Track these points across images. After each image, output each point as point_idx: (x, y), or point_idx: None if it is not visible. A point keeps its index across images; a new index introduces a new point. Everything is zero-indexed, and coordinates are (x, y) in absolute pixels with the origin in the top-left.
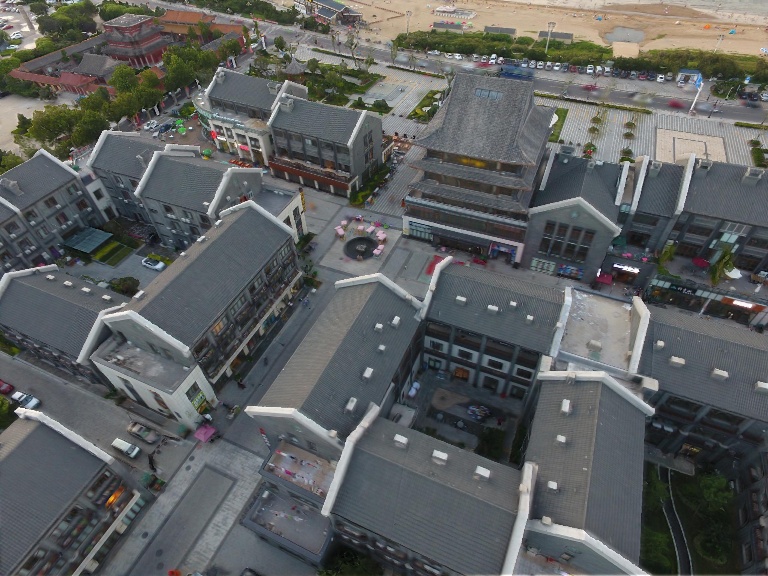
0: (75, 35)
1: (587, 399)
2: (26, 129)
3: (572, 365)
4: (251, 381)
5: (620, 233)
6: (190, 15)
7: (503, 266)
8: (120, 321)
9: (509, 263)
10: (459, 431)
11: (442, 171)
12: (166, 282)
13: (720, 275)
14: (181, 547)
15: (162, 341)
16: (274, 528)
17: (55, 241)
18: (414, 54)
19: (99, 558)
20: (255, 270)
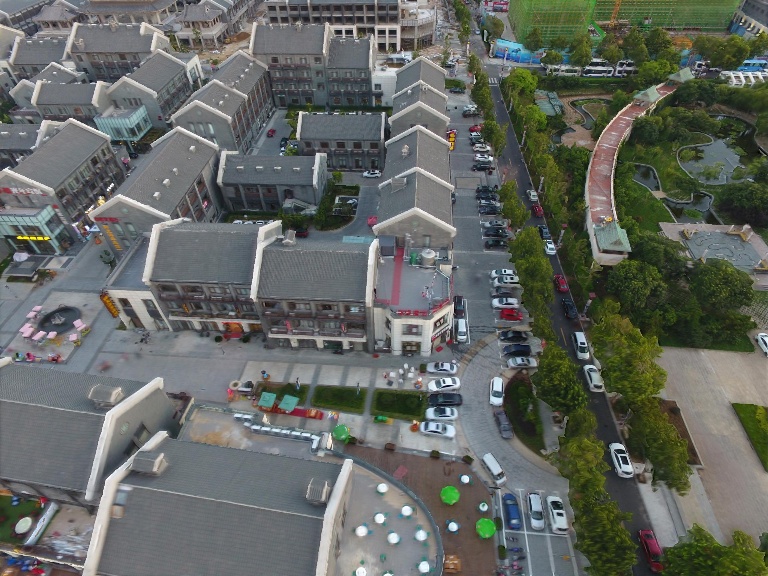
0: None
1: None
2: None
3: None
4: None
5: None
6: None
7: None
8: None
9: None
10: None
11: None
12: (172, 149)
13: None
14: None
15: None
16: None
17: None
18: None
19: None
20: None
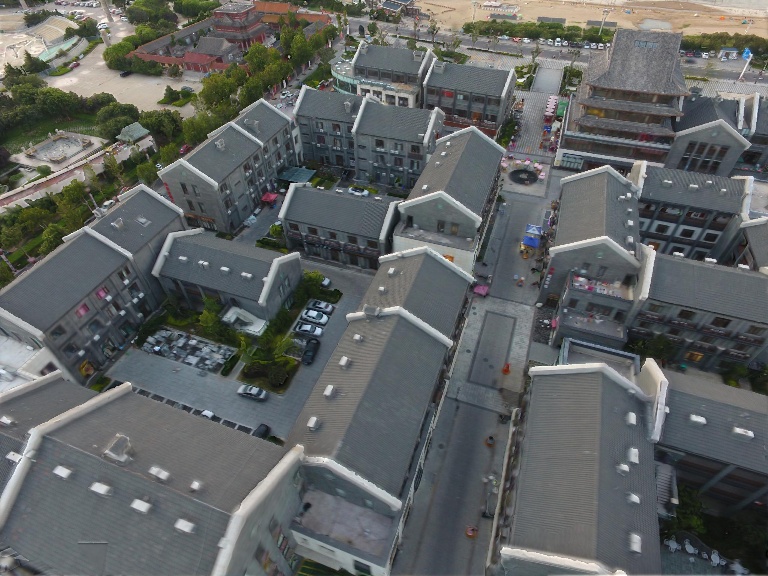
0: (167, 24)
1: None
2: (172, 99)
3: None
4: (489, 262)
5: None
6: (277, 6)
7: None
8: (422, 203)
9: None
10: None
11: (606, 106)
12: (444, 178)
13: None
14: (500, 356)
15: (460, 215)
16: None
17: (273, 175)
18: (485, 39)
19: None
20: (492, 174)
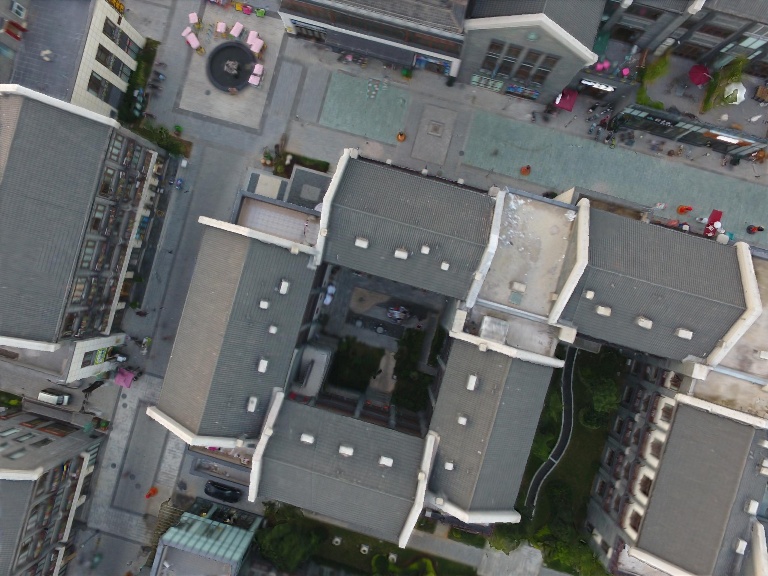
0: None
1: (494, 375)
2: None
3: (488, 320)
4: (151, 305)
5: (602, 26)
6: None
7: (434, 81)
8: None
9: (442, 75)
10: (379, 336)
11: None
12: None
13: (717, 96)
14: (149, 471)
15: None
16: (219, 469)
17: None
18: None
19: (84, 491)
20: (85, 207)
